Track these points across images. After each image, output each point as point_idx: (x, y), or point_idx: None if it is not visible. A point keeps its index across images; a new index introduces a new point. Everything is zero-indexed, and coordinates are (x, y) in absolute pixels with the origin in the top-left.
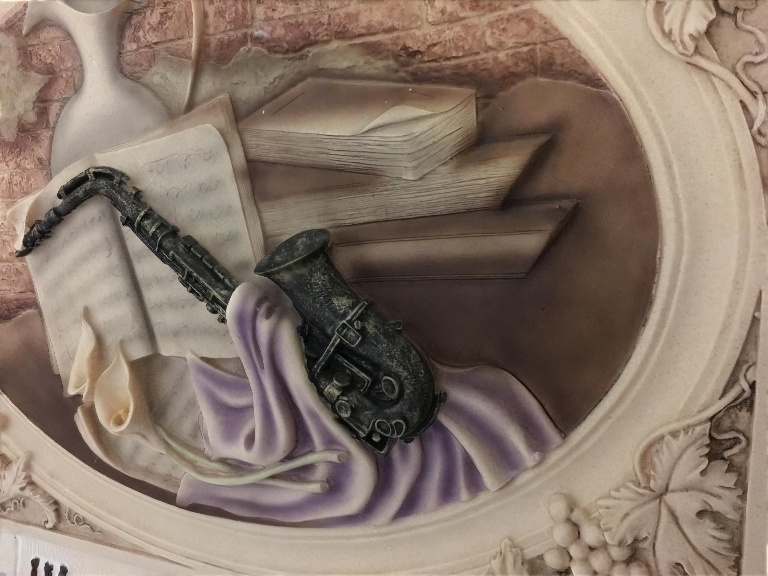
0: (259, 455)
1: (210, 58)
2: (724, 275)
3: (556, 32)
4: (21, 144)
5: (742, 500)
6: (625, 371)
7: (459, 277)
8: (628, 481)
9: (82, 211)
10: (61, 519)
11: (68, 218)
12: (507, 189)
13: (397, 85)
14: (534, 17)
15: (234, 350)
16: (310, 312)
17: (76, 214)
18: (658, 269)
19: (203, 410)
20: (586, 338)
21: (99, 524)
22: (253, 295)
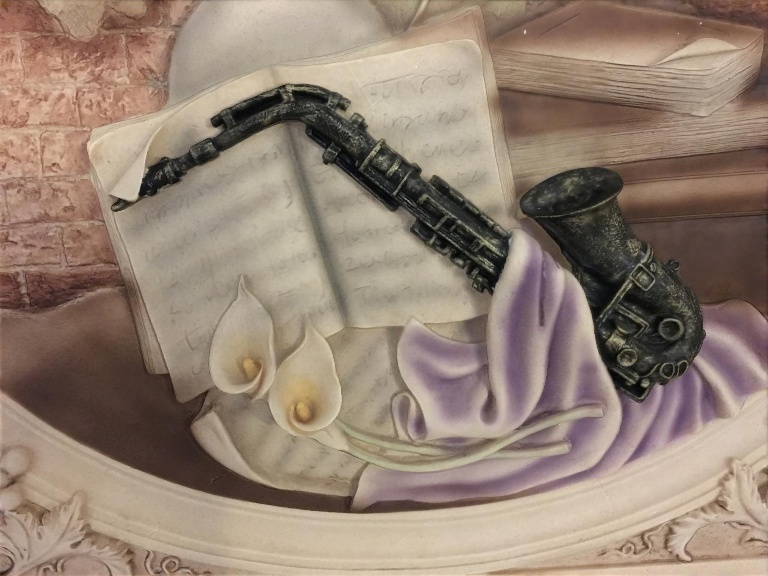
0: (503, 426)
1: None
2: None
3: None
4: (105, 46)
5: None
6: None
7: (720, 215)
8: None
9: (246, 145)
10: (137, 572)
11: (224, 154)
12: None
13: (686, 17)
14: None
15: (467, 311)
16: (600, 257)
17: (236, 149)
18: None
19: (413, 387)
20: None
21: (215, 562)
22: (535, 242)
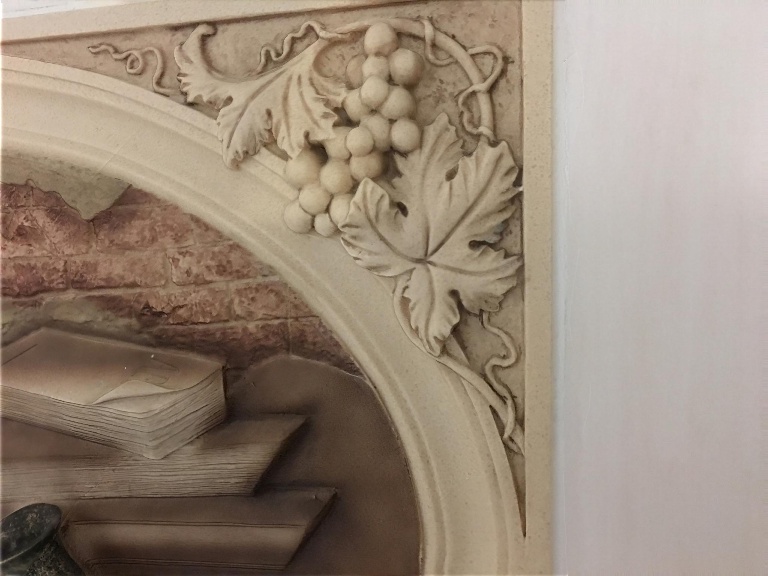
0: None
1: None
2: None
3: (306, 309)
4: None
5: None
6: None
7: (213, 564)
8: None
9: None
10: None
11: None
12: (258, 477)
13: (139, 348)
14: (283, 290)
15: None
16: None
17: None
18: (421, 570)
19: None
20: None
21: None
22: None
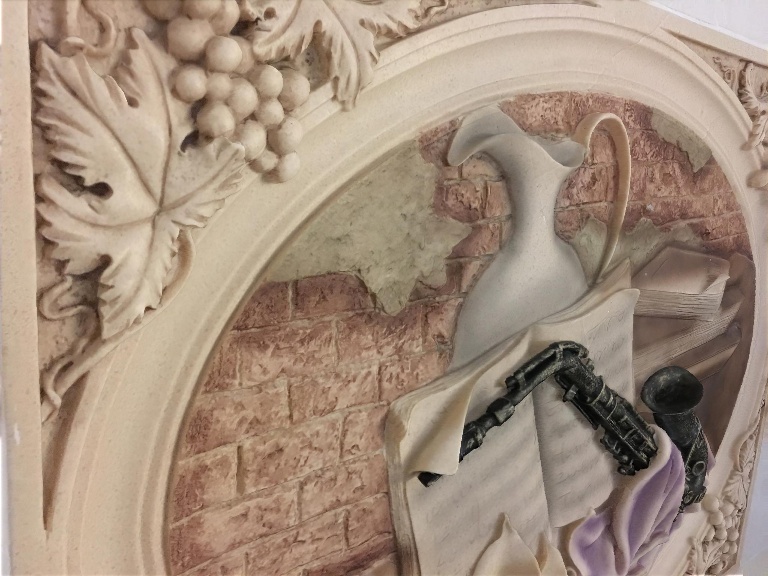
0: None
1: None
2: (762, 352)
3: None
4: (408, 318)
5: None
6: (733, 412)
7: None
8: (734, 471)
9: None
10: None
11: None
12: None
13: None
14: None
15: None
16: (685, 433)
17: None
18: None
19: (578, 562)
20: None
21: None
22: None
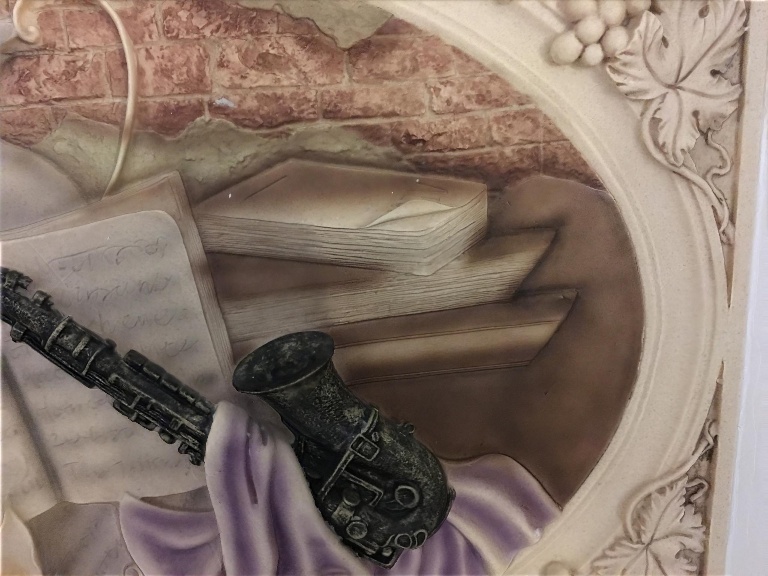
0: None
1: (147, 125)
2: (693, 350)
3: (559, 133)
4: None
5: (706, 535)
6: (613, 440)
7: (464, 370)
8: (620, 539)
9: None
10: None
11: None
12: (520, 283)
13: (402, 174)
14: (539, 117)
15: (190, 482)
16: (315, 429)
17: None
18: (643, 348)
19: (140, 562)
20: (580, 415)
21: None
22: (240, 418)
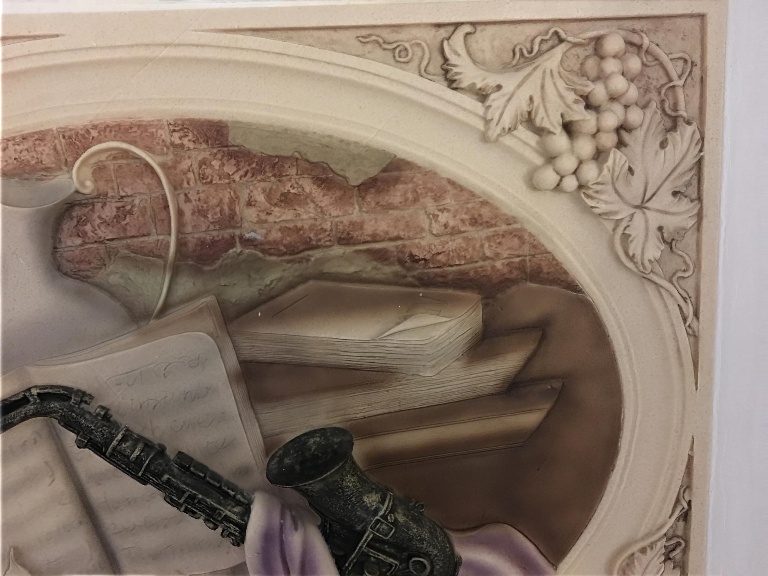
0: None
1: (187, 258)
2: (667, 426)
3: (543, 247)
4: None
5: None
6: (600, 507)
7: (466, 452)
8: None
9: (6, 435)
10: None
11: None
12: (512, 378)
13: (407, 290)
14: (525, 235)
15: (231, 559)
16: (339, 514)
17: None
18: (622, 427)
19: None
20: (569, 486)
21: None
22: (275, 508)
